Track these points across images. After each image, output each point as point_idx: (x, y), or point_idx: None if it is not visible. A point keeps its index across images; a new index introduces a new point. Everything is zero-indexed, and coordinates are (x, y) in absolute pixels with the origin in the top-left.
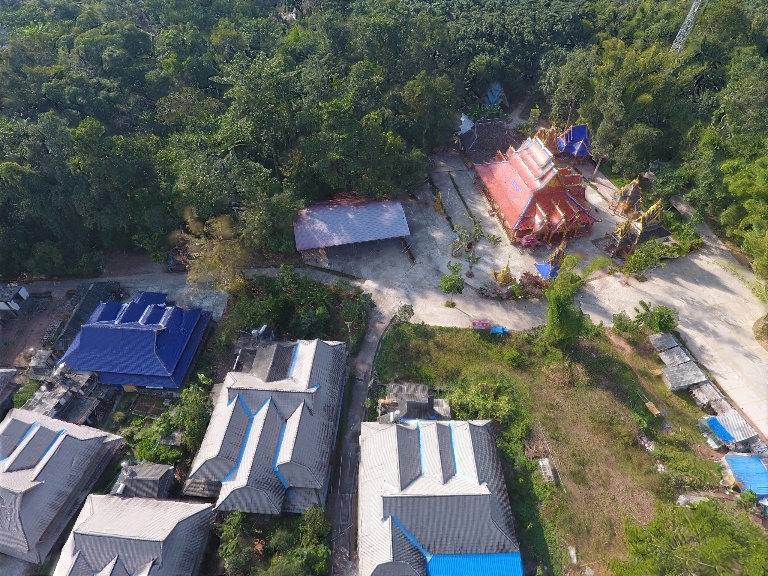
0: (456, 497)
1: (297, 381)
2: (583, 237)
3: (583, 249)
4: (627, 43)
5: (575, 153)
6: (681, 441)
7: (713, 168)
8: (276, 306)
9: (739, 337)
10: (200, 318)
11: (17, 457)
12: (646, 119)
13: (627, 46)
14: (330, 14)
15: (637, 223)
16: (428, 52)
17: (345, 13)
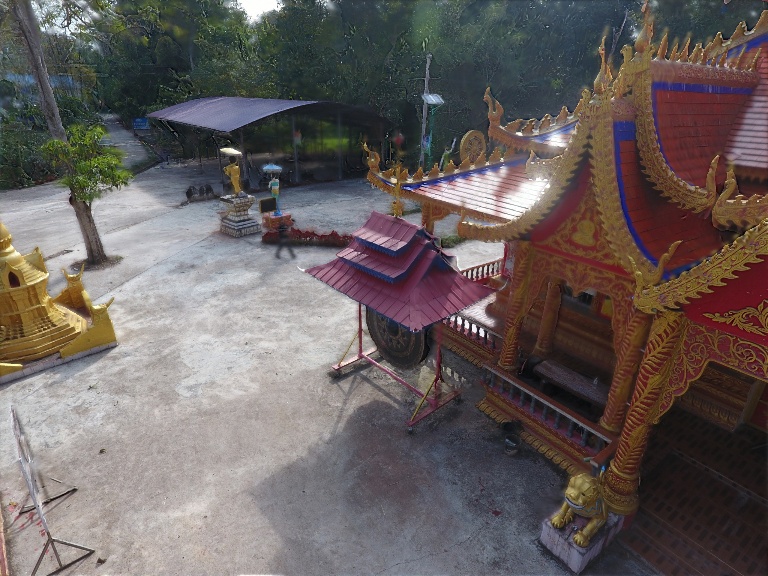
0: None
1: None
2: None
3: None
4: None
5: None
6: None
7: None
8: None
9: None
10: None
11: None
12: None
13: None
14: None
15: None
16: None
17: None
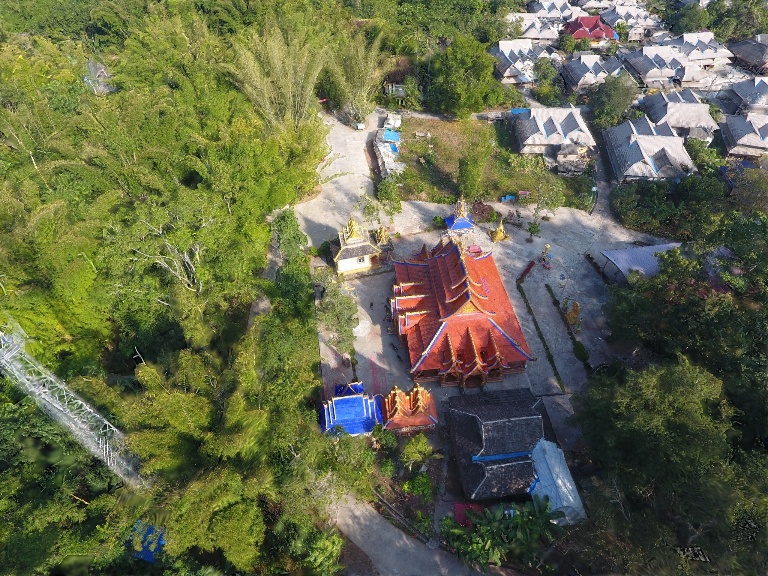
0: None
1: (645, 151)
2: None
3: None
4: None
5: (361, 383)
6: None
7: None
8: None
9: (332, 193)
10: None
11: None
12: None
13: None
14: None
15: (368, 235)
16: None
17: None
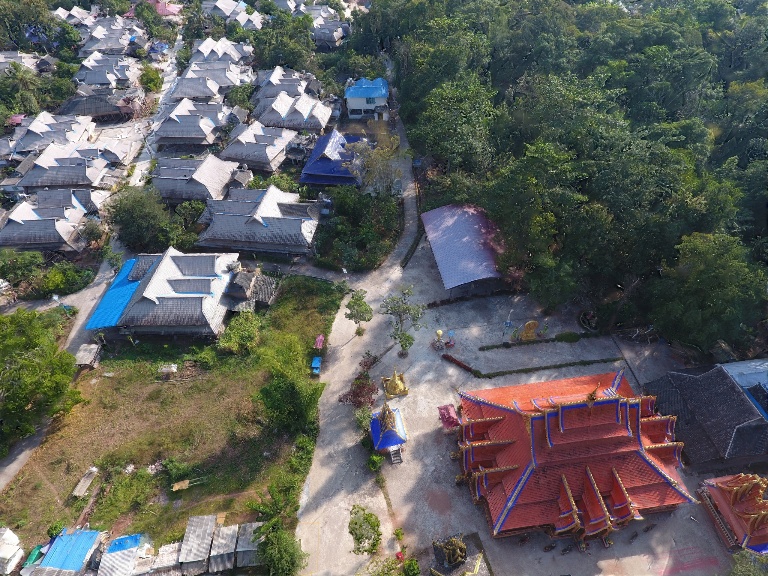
0: None
1: None
2: (485, 522)
3: (455, 510)
4: None
5: None
6: (141, 504)
7: None
8: (340, 198)
9: None
10: (351, 178)
11: (261, 135)
12: None
13: None
14: None
15: None
16: None
17: None
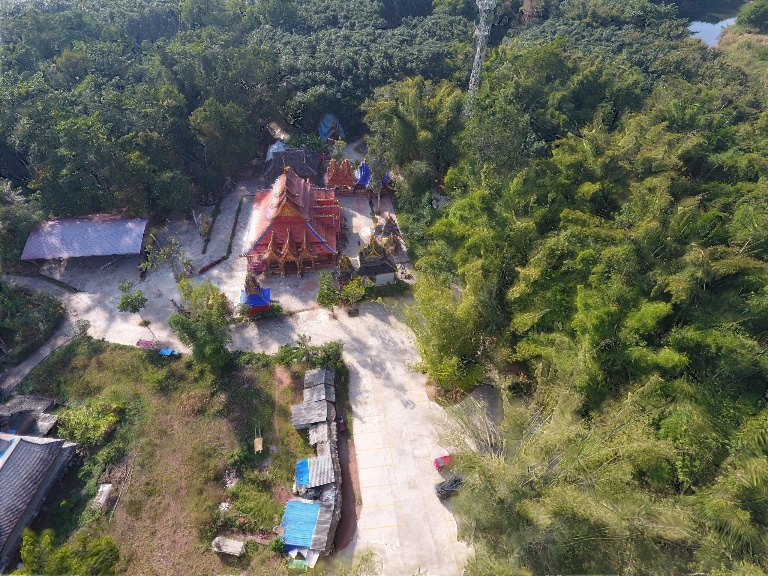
0: None
1: None
2: (326, 268)
3: (317, 280)
4: (435, 82)
5: (366, 186)
6: (266, 481)
7: (430, 207)
8: None
9: (410, 381)
10: None
11: None
12: (426, 156)
13: (435, 85)
14: (160, 41)
15: (358, 257)
16: (233, 81)
17: (175, 41)
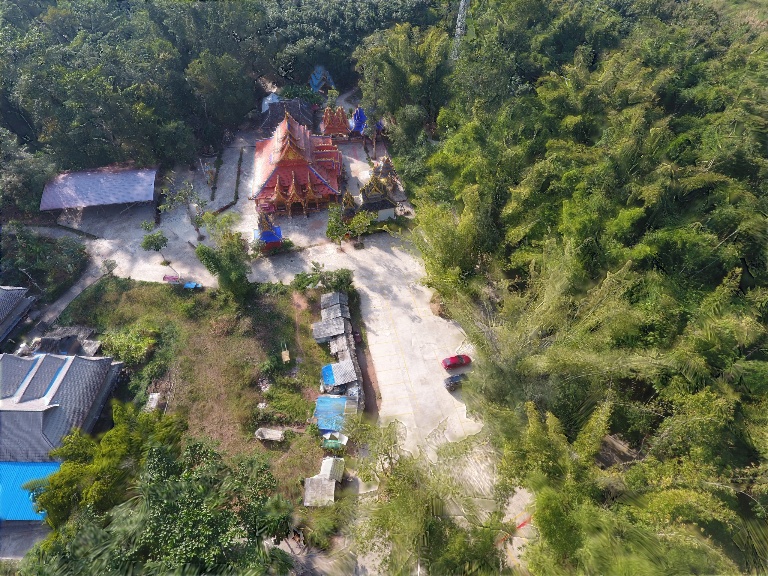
0: (12, 412)
1: None
2: None
3: (323, 219)
4: (422, 28)
5: (361, 132)
6: (296, 385)
7: (426, 144)
8: None
9: (415, 300)
10: None
11: None
12: (418, 100)
13: (422, 31)
14: None
15: (361, 195)
16: (225, 33)
17: None
